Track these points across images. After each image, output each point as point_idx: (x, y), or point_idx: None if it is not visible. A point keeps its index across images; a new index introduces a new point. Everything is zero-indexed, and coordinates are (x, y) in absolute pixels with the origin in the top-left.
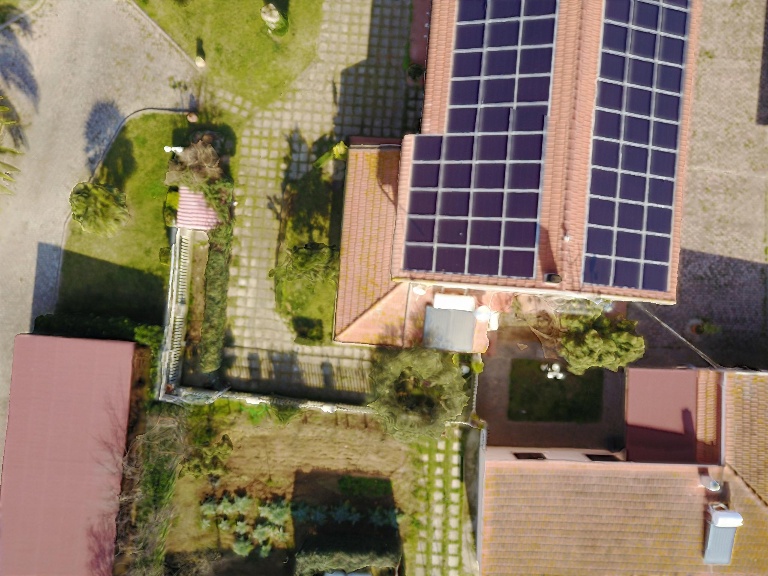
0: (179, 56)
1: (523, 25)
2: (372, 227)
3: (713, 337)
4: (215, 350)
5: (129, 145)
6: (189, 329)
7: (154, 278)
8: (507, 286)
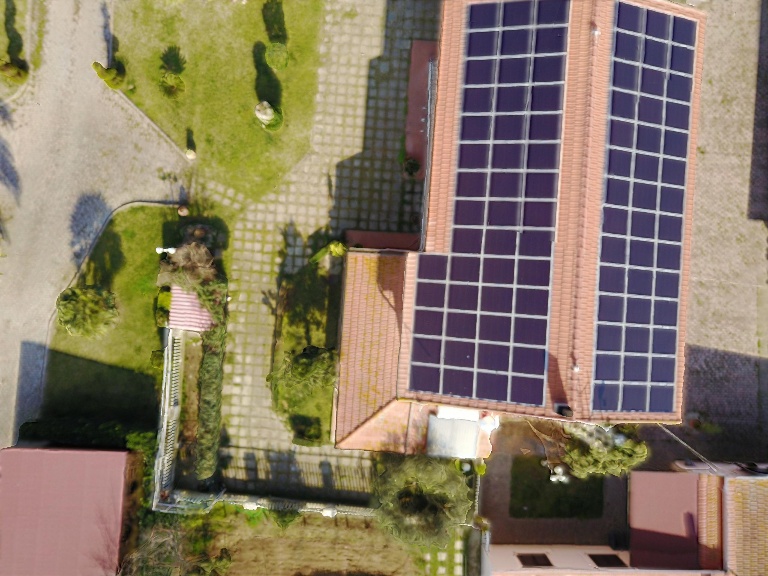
0: (168, 147)
1: (529, 148)
2: (373, 333)
3: (709, 429)
4: (210, 456)
5: (117, 239)
6: (182, 429)
7: (144, 378)
8: (516, 413)
